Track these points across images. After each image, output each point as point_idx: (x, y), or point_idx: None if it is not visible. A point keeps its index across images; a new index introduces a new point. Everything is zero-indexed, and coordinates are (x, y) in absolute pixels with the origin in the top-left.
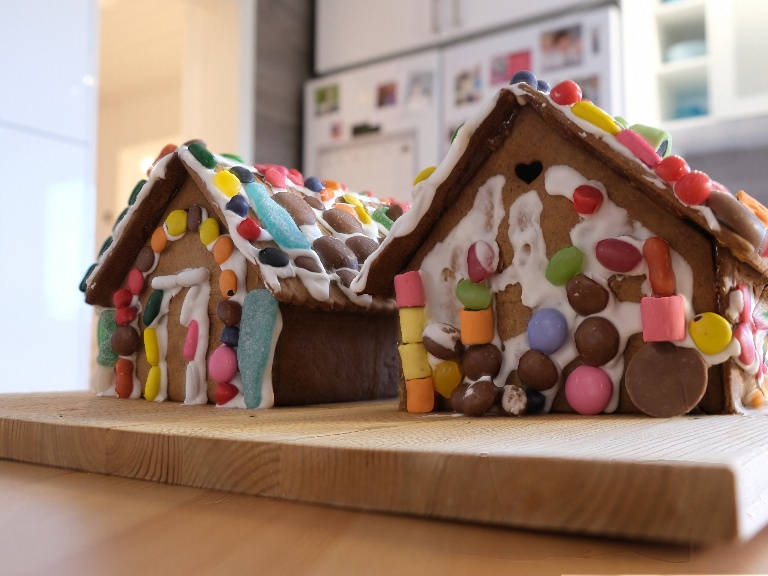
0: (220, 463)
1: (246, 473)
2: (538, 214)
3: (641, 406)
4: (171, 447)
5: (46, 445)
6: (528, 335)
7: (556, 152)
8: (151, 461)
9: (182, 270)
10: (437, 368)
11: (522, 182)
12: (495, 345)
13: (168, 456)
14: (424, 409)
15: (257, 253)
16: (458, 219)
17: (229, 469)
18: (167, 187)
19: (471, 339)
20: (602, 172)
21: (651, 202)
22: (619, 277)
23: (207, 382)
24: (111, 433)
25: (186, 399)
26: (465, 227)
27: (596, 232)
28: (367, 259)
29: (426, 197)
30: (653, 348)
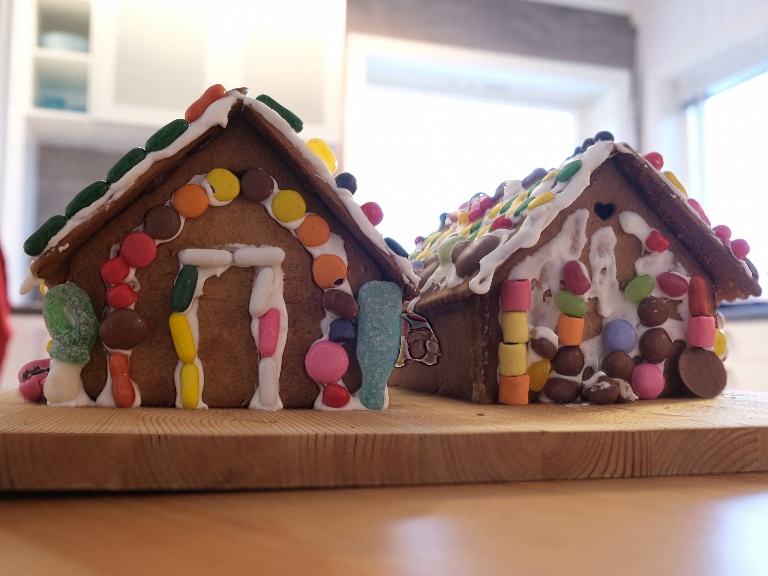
0: (697, 450)
1: (726, 455)
2: (614, 246)
3: (696, 391)
4: (637, 442)
5: (432, 460)
6: (607, 339)
7: (628, 201)
8: (611, 458)
9: (227, 244)
10: (537, 365)
11: (600, 218)
12: (578, 346)
13: (634, 451)
14: (527, 401)
15: (385, 242)
16: (548, 238)
17: (707, 454)
18: (203, 136)
19: (576, 341)
20: (658, 223)
21: (685, 250)
22: (664, 300)
23: (280, 383)
24: (551, 436)
25: (268, 403)
26: (558, 246)
27: (655, 266)
28: (488, 263)
29: (551, 217)
30: (691, 351)
